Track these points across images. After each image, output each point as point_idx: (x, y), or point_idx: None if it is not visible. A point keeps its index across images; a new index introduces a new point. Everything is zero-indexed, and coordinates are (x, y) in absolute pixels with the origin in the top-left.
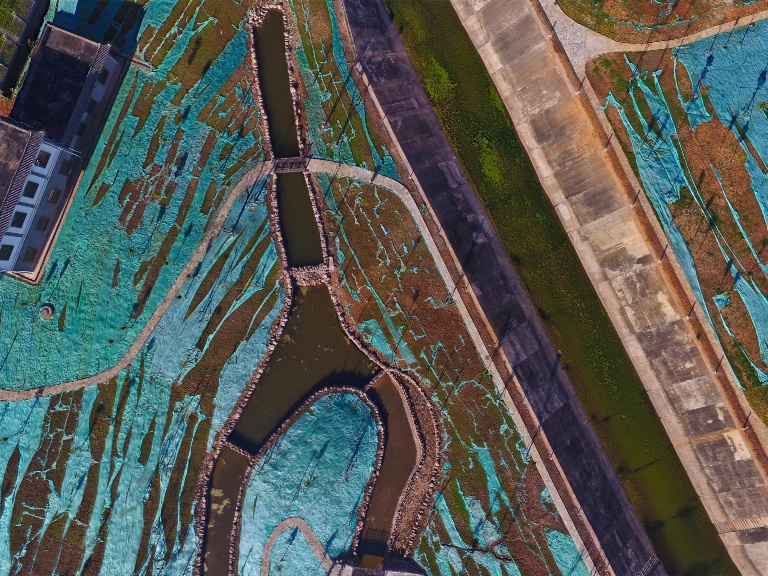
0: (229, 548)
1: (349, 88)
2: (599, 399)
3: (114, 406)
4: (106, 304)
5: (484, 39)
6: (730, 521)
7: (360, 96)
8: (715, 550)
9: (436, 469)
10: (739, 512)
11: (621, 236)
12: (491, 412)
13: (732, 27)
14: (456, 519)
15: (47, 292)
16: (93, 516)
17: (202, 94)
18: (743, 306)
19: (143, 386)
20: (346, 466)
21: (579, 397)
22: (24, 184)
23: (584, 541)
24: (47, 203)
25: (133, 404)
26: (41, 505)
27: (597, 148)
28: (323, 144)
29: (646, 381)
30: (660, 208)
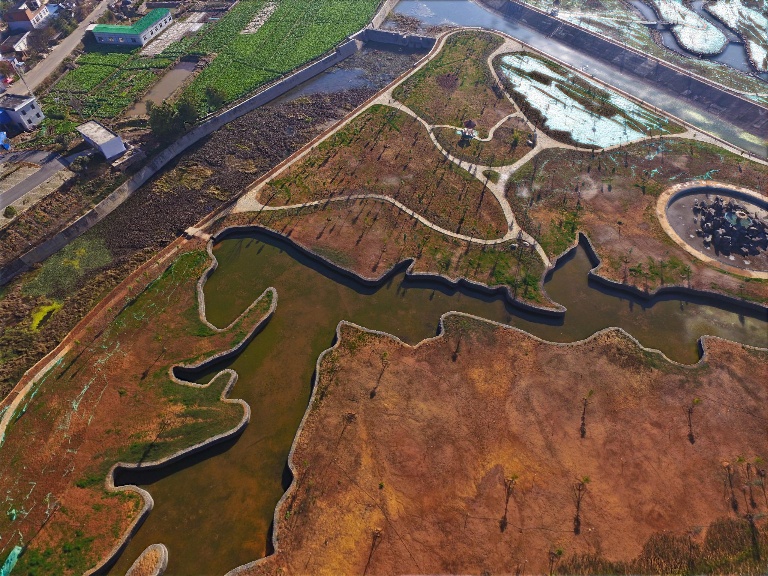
0: None
1: None
2: None
3: None
4: None
5: None
6: None
7: None
8: None
9: None
10: None
11: None
12: None
13: (622, 144)
14: None
15: None
16: None
17: None
18: None
19: None
20: None
21: (604, 65)
22: None
23: None
24: None
25: None
26: None
27: None
28: None
29: None
30: None
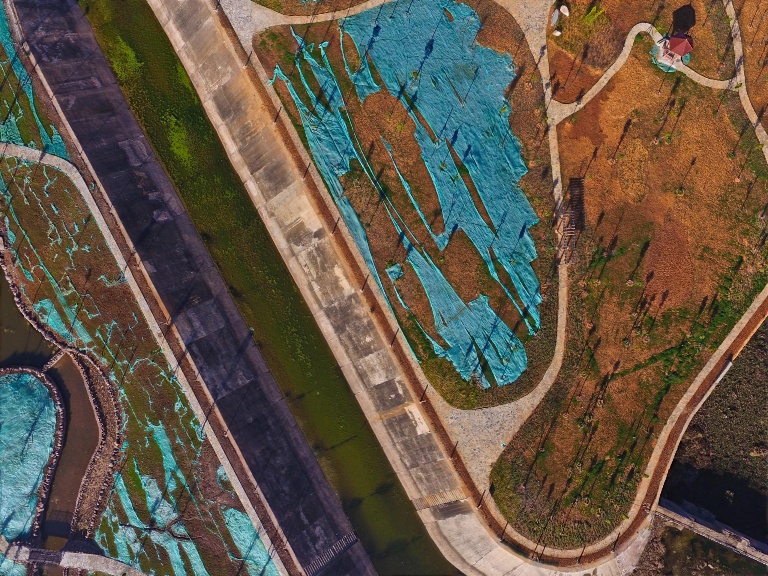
0: None
1: (15, 68)
2: (293, 376)
3: None
4: None
5: (167, 17)
6: (423, 497)
7: (27, 76)
8: (414, 527)
9: (115, 449)
10: (429, 488)
11: (298, 210)
12: (165, 390)
13: None
14: (133, 498)
15: None
16: None
17: None
18: (416, 278)
19: None
20: (21, 447)
21: (272, 374)
22: None
23: (261, 519)
24: None
25: None
26: None
27: (267, 122)
28: None
29: (339, 357)
30: (331, 181)
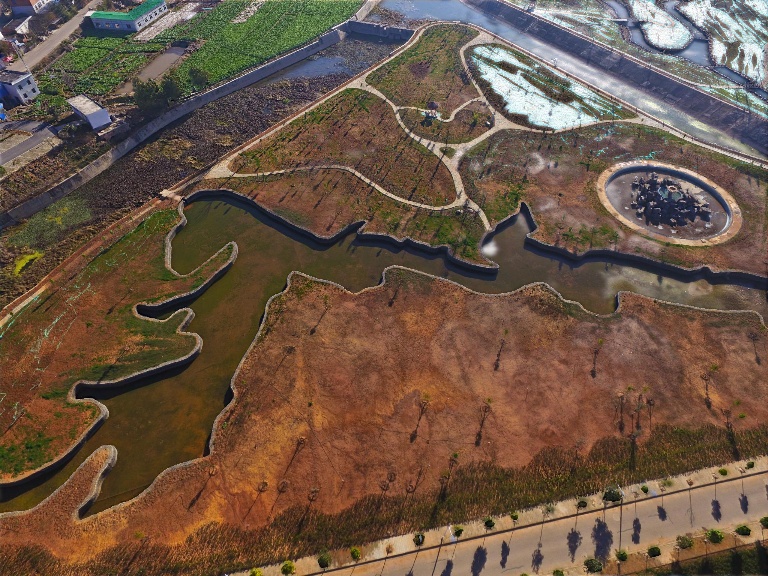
0: None
1: None
2: None
3: None
4: None
5: None
6: None
7: None
8: None
9: None
10: None
11: None
12: None
13: None
14: None
15: None
16: None
17: None
18: None
19: None
20: None
21: (572, 58)
22: None
23: None
24: None
25: None
26: None
27: None
28: (742, 92)
29: None
30: None
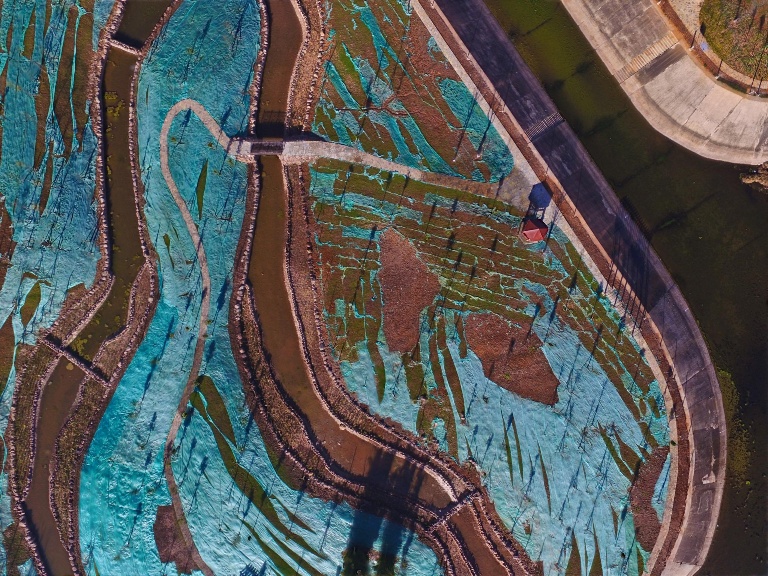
0: (128, 145)
1: None
2: None
3: None
4: None
5: None
6: (627, 64)
7: None
8: (618, 102)
9: (322, 39)
10: (634, 49)
11: None
12: None
13: None
14: (347, 82)
15: None
16: None
17: None
18: None
19: None
20: (231, 43)
21: None
22: None
23: (477, 85)
24: None
25: None
26: None
27: None
28: None
29: None
30: None
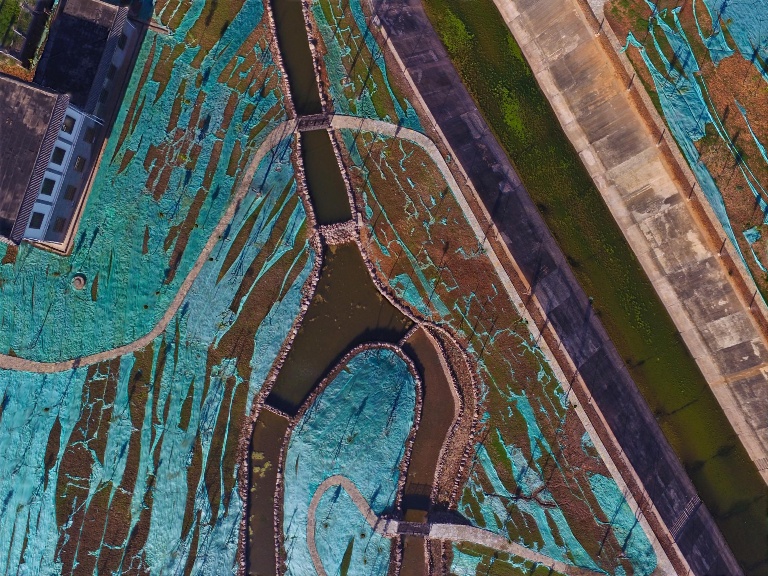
0: (273, 510)
1: (368, 42)
2: (633, 343)
3: (151, 373)
4: (138, 271)
5: None
6: None
7: (379, 50)
8: (756, 487)
9: (475, 420)
10: None
11: (648, 177)
12: (527, 360)
13: None
14: (498, 468)
15: (78, 262)
16: (137, 484)
17: (221, 55)
18: None
19: (179, 352)
20: (386, 421)
21: (613, 342)
22: (53, 149)
23: (627, 483)
24: (74, 171)
25: (170, 370)
26: (85, 475)
27: (620, 89)
28: (345, 100)
29: (679, 322)
30: (686, 146)
